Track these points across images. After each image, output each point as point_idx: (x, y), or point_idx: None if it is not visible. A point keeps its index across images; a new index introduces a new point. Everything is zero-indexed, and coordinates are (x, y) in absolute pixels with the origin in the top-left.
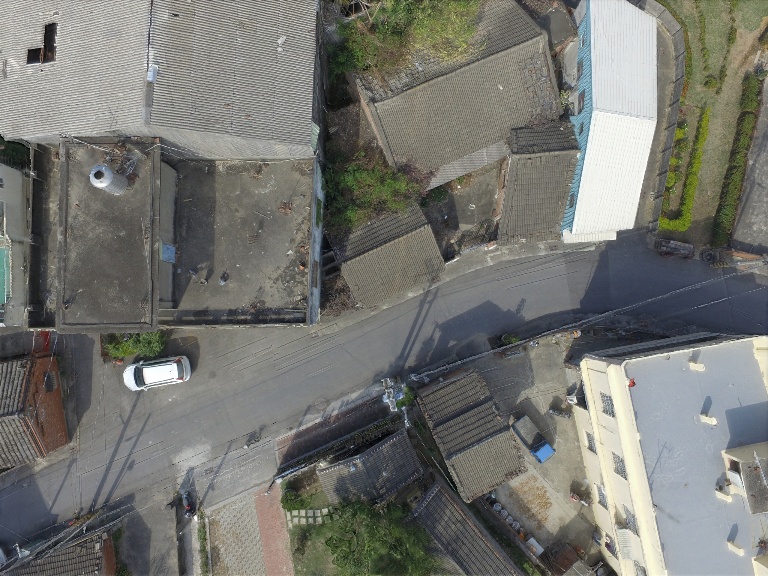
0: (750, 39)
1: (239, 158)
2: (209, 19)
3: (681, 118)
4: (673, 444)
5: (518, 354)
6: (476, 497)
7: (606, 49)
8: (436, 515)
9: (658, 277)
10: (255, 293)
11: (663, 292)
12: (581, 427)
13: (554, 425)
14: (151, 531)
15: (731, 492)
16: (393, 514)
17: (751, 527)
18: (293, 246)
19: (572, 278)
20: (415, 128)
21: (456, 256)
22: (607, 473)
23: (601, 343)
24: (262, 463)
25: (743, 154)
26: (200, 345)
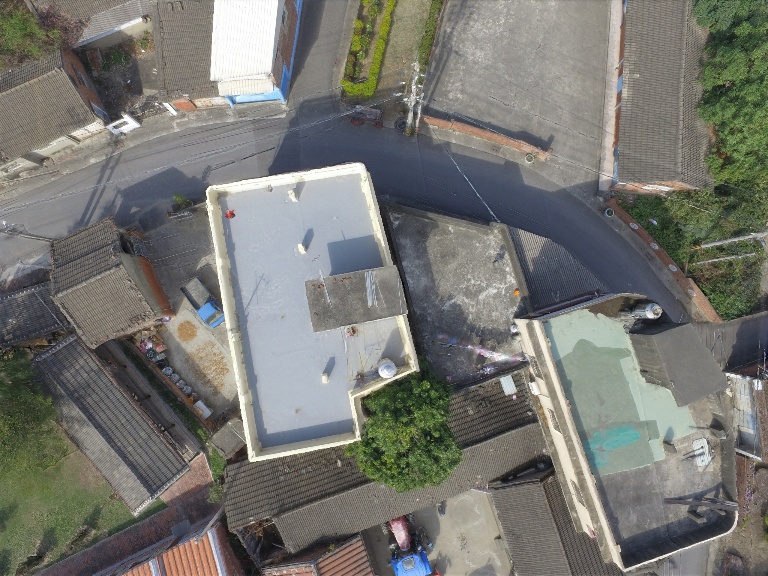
0: None
1: None
2: None
3: None
4: (271, 276)
5: (186, 214)
6: (101, 342)
7: None
8: (66, 363)
9: (350, 145)
10: None
11: (355, 160)
12: None
13: None
14: None
15: None
16: (20, 361)
17: (349, 360)
18: None
19: (260, 145)
20: None
21: (121, 113)
22: None
23: None
24: None
25: (434, 19)
26: None
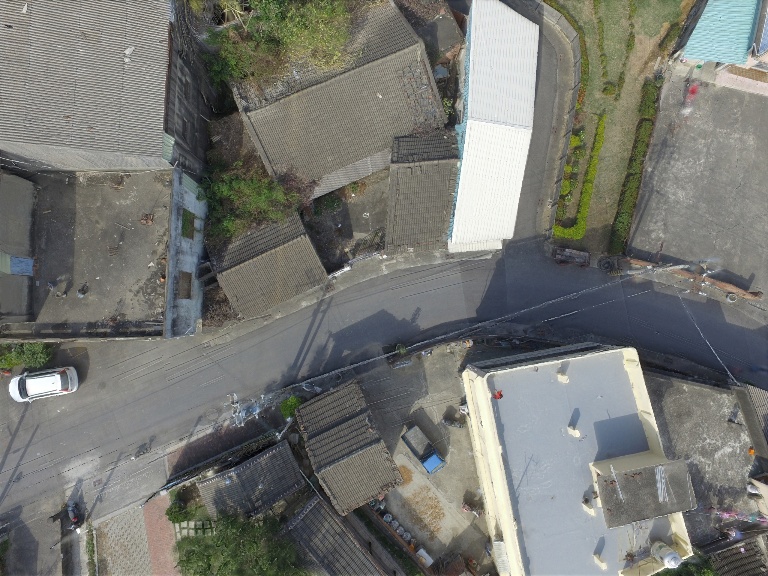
0: (650, 45)
1: (98, 169)
2: (47, 30)
3: (576, 125)
4: (540, 457)
5: (407, 364)
6: None
7: (485, 57)
8: (313, 528)
9: (555, 285)
10: (115, 306)
11: None
12: (472, 437)
13: (448, 435)
14: (38, 544)
15: (598, 505)
16: (269, 527)
17: (618, 540)
18: (154, 258)
19: (468, 287)
20: (293, 137)
21: (344, 265)
22: (488, 484)
23: (496, 352)
24: (151, 474)
25: (640, 161)
26: (90, 356)
